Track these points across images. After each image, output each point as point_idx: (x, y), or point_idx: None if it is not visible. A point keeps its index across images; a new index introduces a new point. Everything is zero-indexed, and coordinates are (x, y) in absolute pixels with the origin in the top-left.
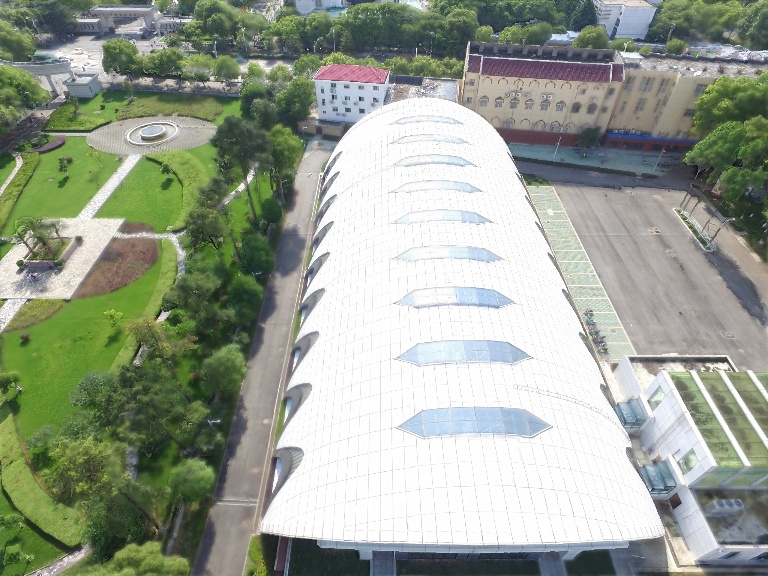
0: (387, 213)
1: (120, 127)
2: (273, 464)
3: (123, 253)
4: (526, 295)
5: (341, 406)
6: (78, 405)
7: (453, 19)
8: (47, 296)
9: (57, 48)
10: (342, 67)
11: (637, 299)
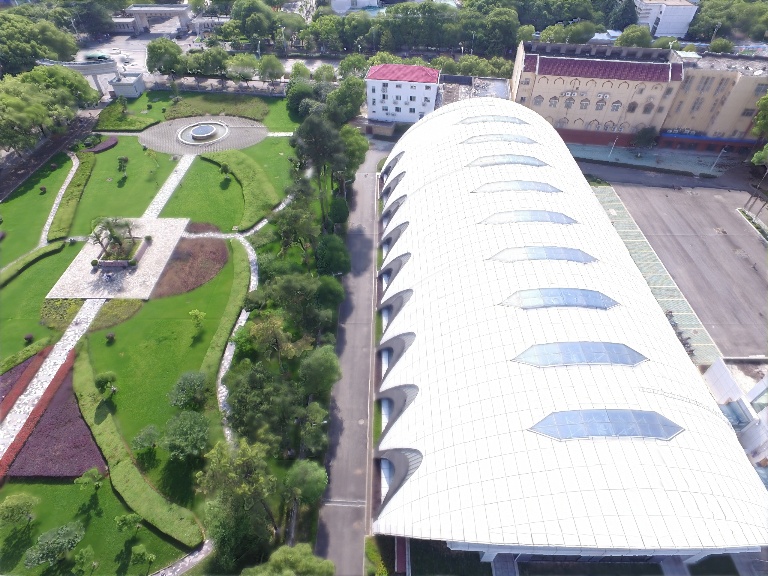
0: (471, 213)
1: (170, 127)
2: (376, 465)
3: (193, 253)
4: (627, 296)
5: (459, 408)
6: (178, 405)
7: (495, 18)
8: (125, 296)
9: (94, 48)
10: (394, 67)
11: (715, 300)
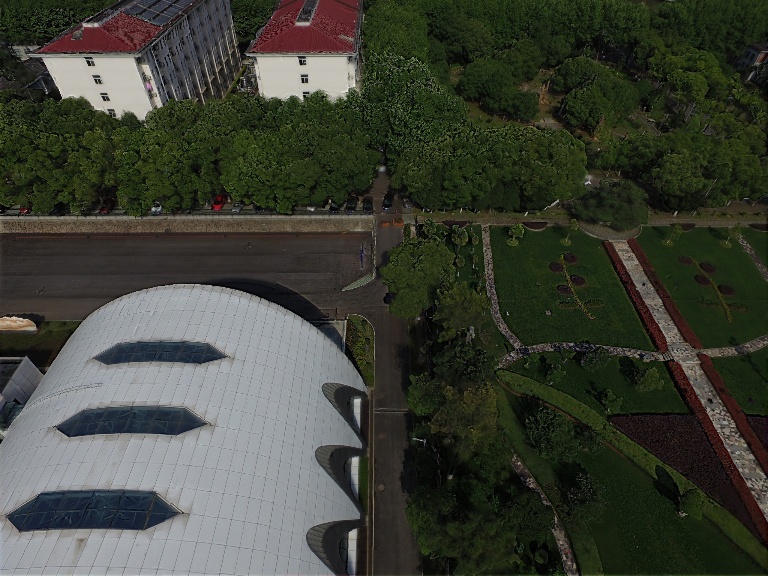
0: None
1: None
2: (365, 440)
3: None
4: None
5: (280, 402)
6: None
7: None
8: None
9: None
10: None
11: None
